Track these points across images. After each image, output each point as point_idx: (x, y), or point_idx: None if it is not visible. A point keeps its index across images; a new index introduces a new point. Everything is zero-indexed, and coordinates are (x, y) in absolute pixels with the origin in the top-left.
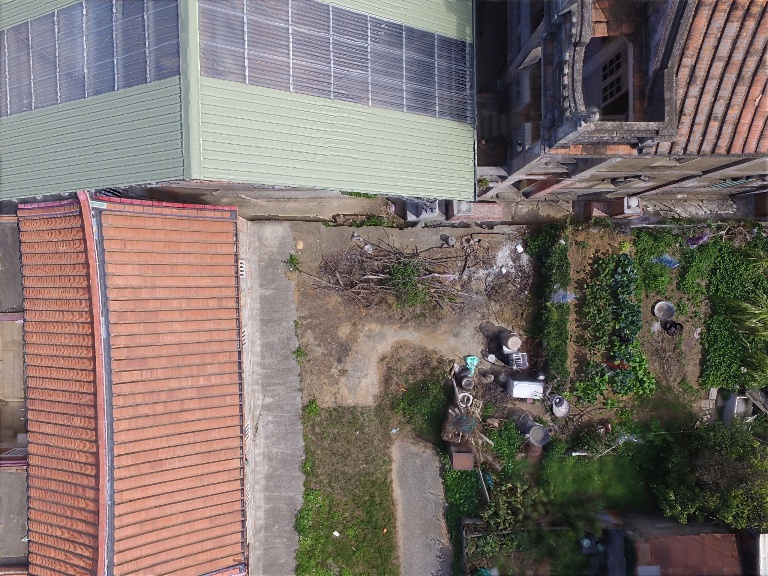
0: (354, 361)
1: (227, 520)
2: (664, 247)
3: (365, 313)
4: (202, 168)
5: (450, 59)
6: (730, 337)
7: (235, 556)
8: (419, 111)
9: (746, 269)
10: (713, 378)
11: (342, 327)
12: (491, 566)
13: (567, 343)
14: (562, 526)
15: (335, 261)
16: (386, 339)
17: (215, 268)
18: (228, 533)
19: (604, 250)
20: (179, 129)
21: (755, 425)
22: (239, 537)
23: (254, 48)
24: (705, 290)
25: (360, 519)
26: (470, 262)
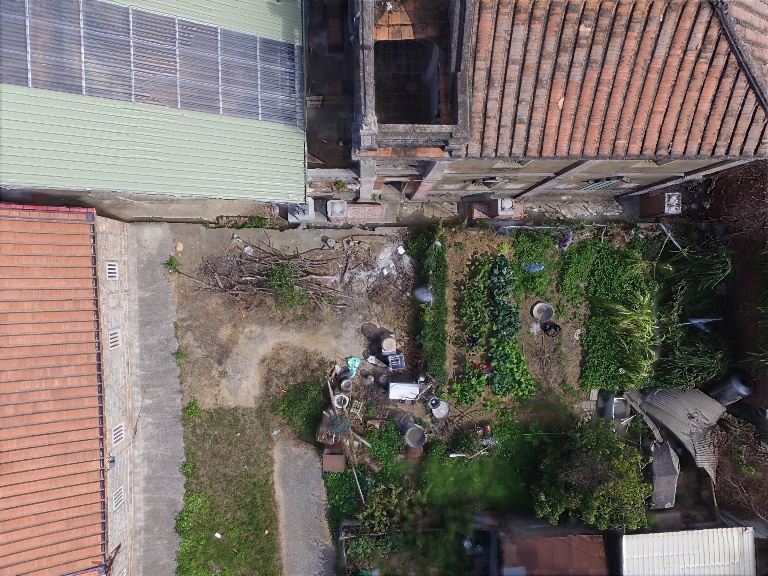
0: (235, 363)
1: (85, 522)
2: (543, 248)
3: (245, 315)
4: None
5: (275, 61)
6: (609, 338)
7: (94, 558)
8: (239, 113)
9: (624, 270)
10: (592, 379)
11: (223, 329)
12: (373, 567)
13: (446, 344)
14: (439, 527)
15: (215, 263)
16: (267, 341)
17: (70, 270)
18: (87, 535)
19: (483, 251)
20: None
21: (631, 426)
22: (99, 539)
23: (38, 51)
24: (584, 291)
25: (242, 521)
26: (351, 264)
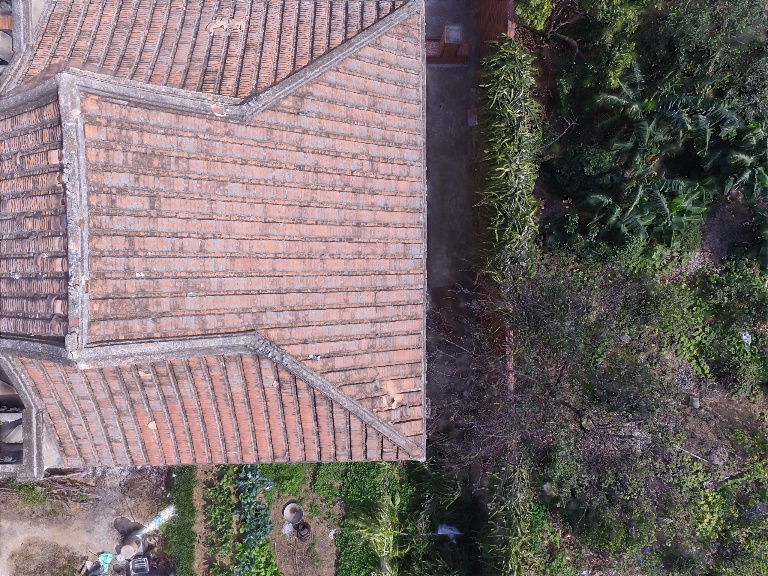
0: None
1: None
2: None
3: None
4: None
5: None
6: (361, 541)
7: None
8: None
9: (377, 472)
10: None
11: None
12: None
13: (195, 545)
14: None
15: None
16: (16, 536)
17: None
18: None
19: None
20: None
21: None
22: None
23: None
24: (338, 491)
25: None
26: None
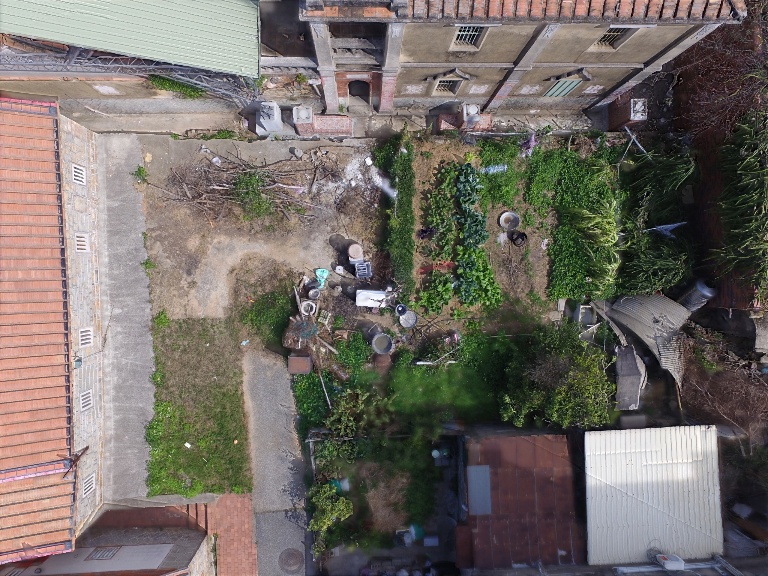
0: (204, 273)
1: (50, 415)
2: (510, 158)
3: (214, 225)
4: None
5: None
6: (575, 247)
7: (59, 451)
8: None
9: (591, 179)
10: (559, 288)
11: (191, 239)
12: (341, 477)
13: (413, 254)
14: (405, 434)
15: (183, 173)
16: (235, 251)
17: (33, 163)
18: (52, 428)
19: (449, 161)
20: None
21: (597, 333)
22: (64, 433)
23: None
24: (551, 201)
25: (211, 431)
26: (319, 175)
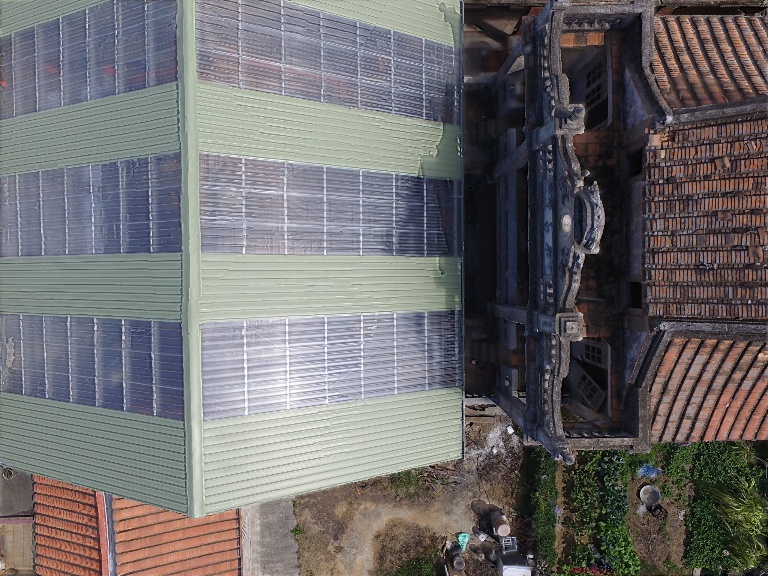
0: (350, 538)
1: None
2: None
3: (361, 492)
4: (204, 506)
5: (440, 331)
6: (713, 521)
7: None
8: (409, 388)
9: (729, 456)
10: (696, 559)
11: (338, 506)
12: None
13: (555, 525)
14: None
15: None
16: (381, 517)
17: None
18: None
19: None
20: (183, 469)
21: None
22: None
23: (253, 379)
24: (689, 474)
25: None
26: None
